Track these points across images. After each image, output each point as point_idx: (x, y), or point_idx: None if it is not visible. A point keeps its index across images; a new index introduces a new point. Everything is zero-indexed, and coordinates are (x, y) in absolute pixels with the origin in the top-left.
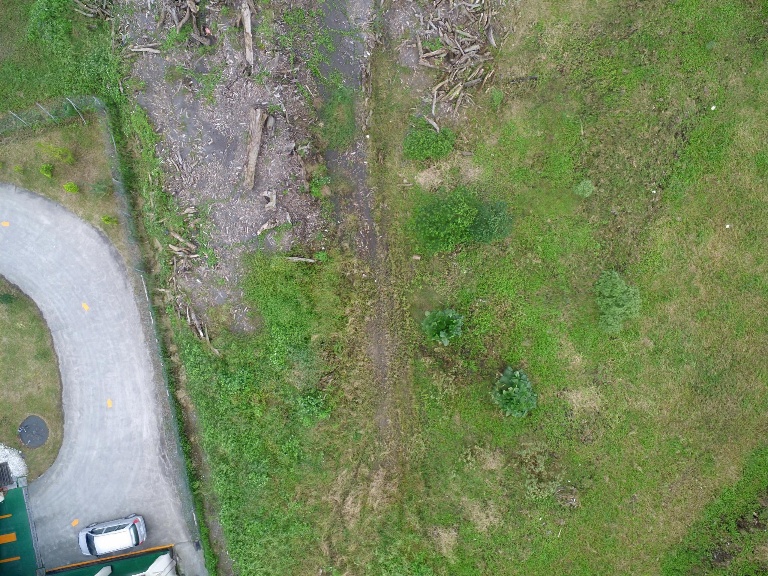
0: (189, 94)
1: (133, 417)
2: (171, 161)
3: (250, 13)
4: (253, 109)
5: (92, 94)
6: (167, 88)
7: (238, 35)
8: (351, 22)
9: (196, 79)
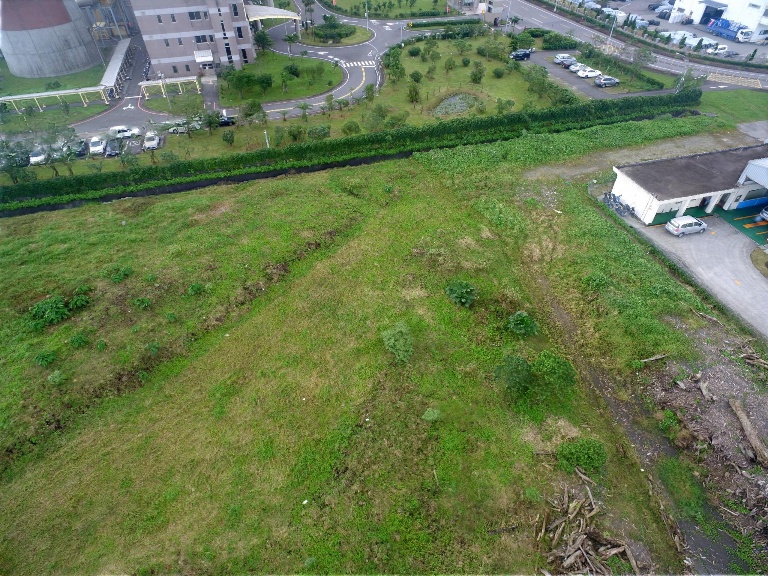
0: None
1: (715, 277)
2: None
3: None
4: None
5: None
6: None
7: None
8: None
9: None
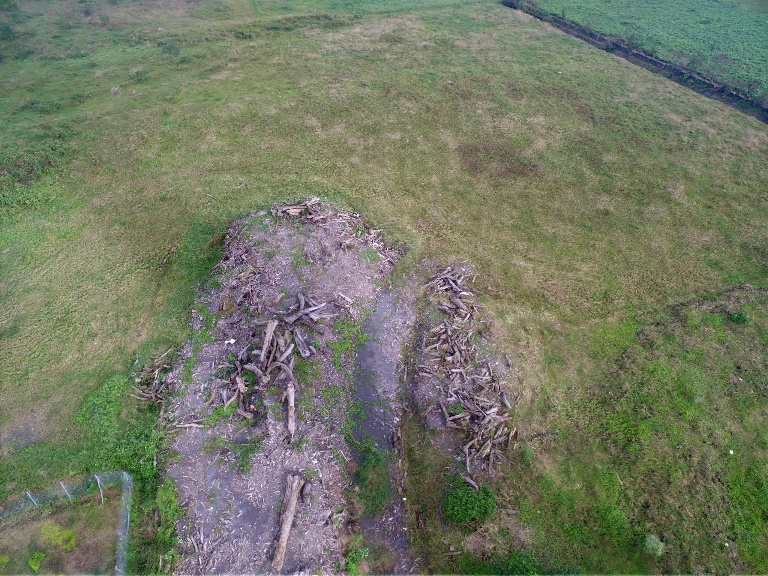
0: (225, 464)
1: None
2: (191, 540)
3: (294, 391)
4: (291, 476)
5: (120, 470)
6: (203, 460)
7: (282, 409)
8: (380, 394)
9: (234, 450)
